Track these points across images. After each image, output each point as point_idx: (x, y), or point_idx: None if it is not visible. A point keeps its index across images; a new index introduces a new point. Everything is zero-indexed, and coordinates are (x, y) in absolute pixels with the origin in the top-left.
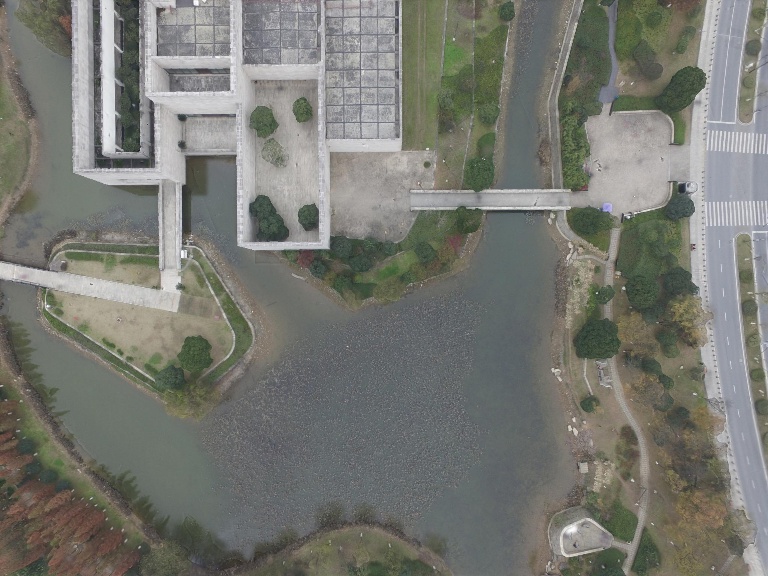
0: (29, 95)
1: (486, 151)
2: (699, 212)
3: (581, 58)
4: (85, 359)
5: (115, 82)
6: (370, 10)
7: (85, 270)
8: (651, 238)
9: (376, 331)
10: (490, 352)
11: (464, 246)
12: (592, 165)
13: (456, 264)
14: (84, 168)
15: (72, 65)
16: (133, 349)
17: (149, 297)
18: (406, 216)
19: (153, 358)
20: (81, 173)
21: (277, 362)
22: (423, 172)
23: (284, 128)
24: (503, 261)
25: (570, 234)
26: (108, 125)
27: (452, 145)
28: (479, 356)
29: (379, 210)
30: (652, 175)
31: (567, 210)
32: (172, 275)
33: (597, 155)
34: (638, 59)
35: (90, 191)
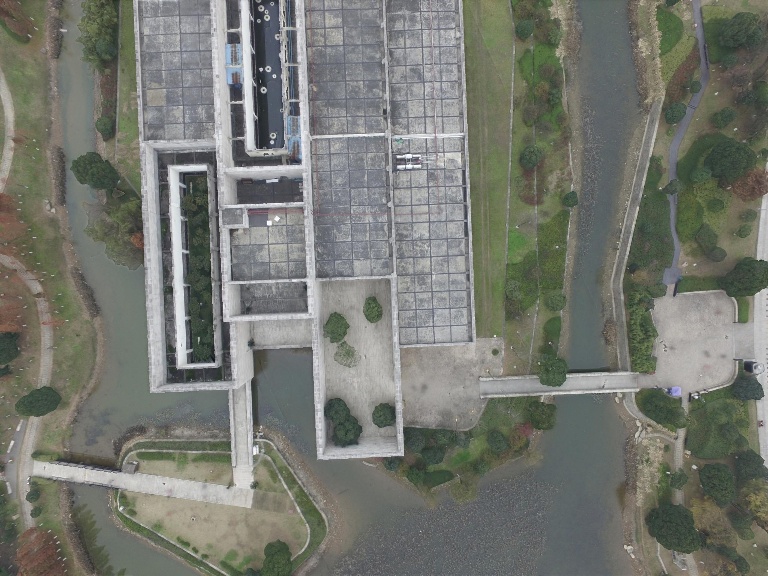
0: (93, 293)
1: (553, 336)
2: (765, 389)
3: (644, 242)
4: (158, 554)
5: (184, 288)
6: (439, 215)
7: (157, 469)
8: (721, 421)
9: (449, 516)
10: (562, 531)
11: (534, 429)
12: (658, 346)
13: (532, 461)
14: (159, 384)
15: (146, 286)
16: (208, 547)
17: (222, 494)
18: (476, 403)
19: (228, 555)
20: None
21: (351, 550)
22: (491, 359)
23: (351, 320)
24: (572, 440)
25: (639, 414)
26: (180, 336)
27: (519, 331)
28: (552, 535)
29: (449, 398)
30: (717, 353)
31: (635, 392)
32: (244, 471)
33: (663, 336)
34: (701, 242)
35: None
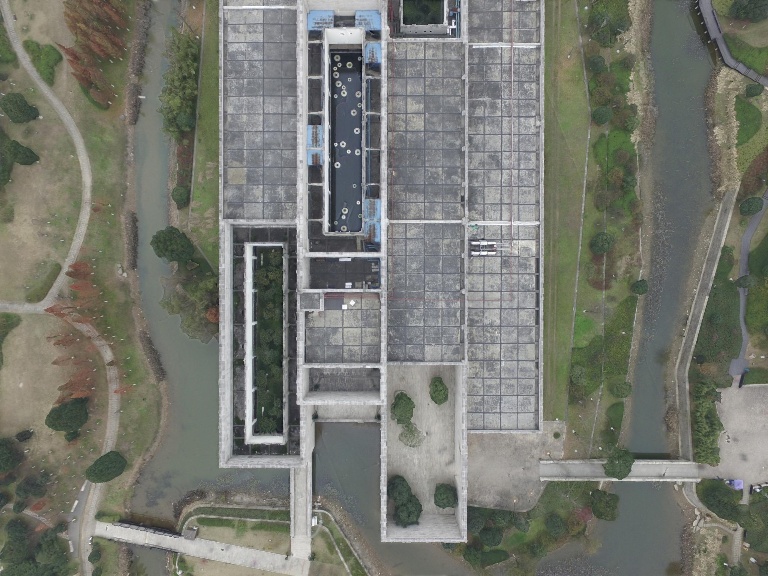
0: (160, 357)
1: (615, 422)
2: None
3: (712, 333)
4: None
5: (252, 360)
6: (511, 302)
7: (216, 535)
8: None
9: None
10: None
11: None
12: (721, 436)
13: (593, 551)
14: (227, 458)
15: (219, 362)
16: None
17: (279, 563)
18: (535, 485)
19: None
20: (226, 467)
21: None
22: (552, 442)
23: (415, 397)
24: (628, 525)
25: (698, 504)
26: (249, 410)
27: (581, 415)
28: None
29: (508, 479)
30: None
31: (696, 483)
32: (302, 541)
33: (726, 426)
34: None
35: (217, 446)
